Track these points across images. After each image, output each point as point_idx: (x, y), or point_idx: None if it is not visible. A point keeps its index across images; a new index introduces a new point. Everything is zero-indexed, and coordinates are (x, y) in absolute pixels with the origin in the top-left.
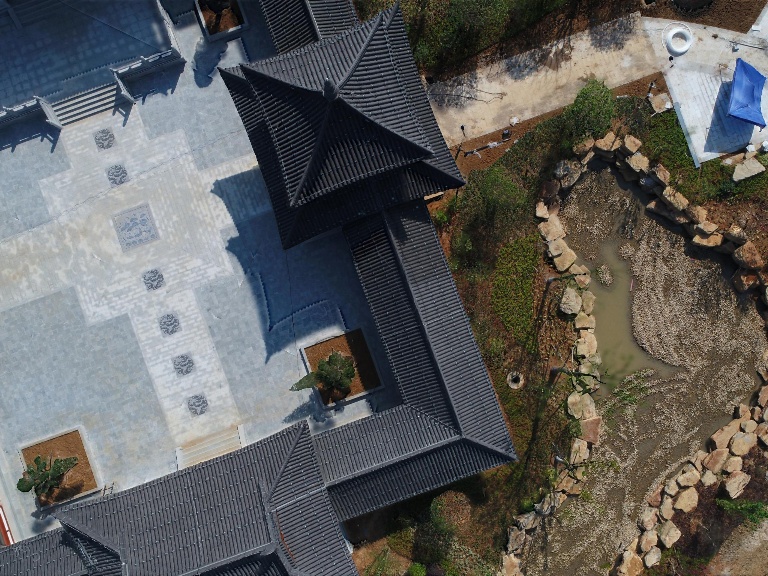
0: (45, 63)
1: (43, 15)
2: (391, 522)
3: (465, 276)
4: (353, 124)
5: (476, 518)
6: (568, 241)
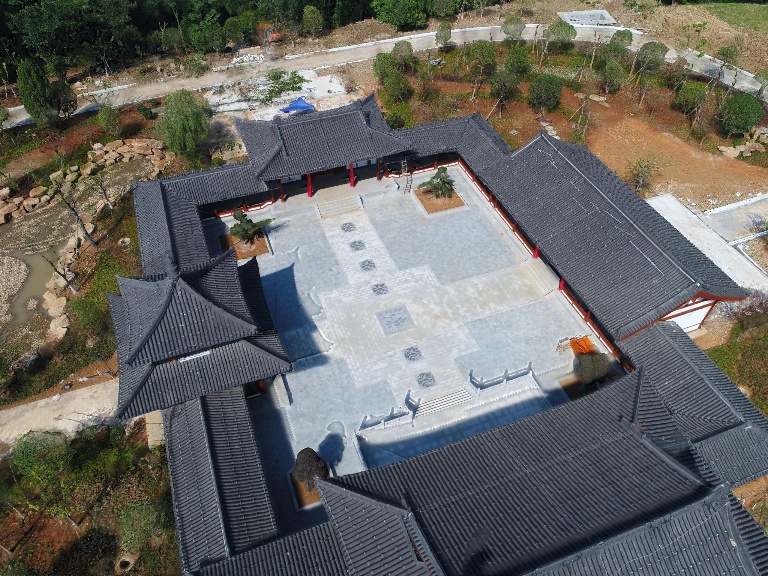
0: None
1: None
2: None
3: None
4: None
5: None
6: None
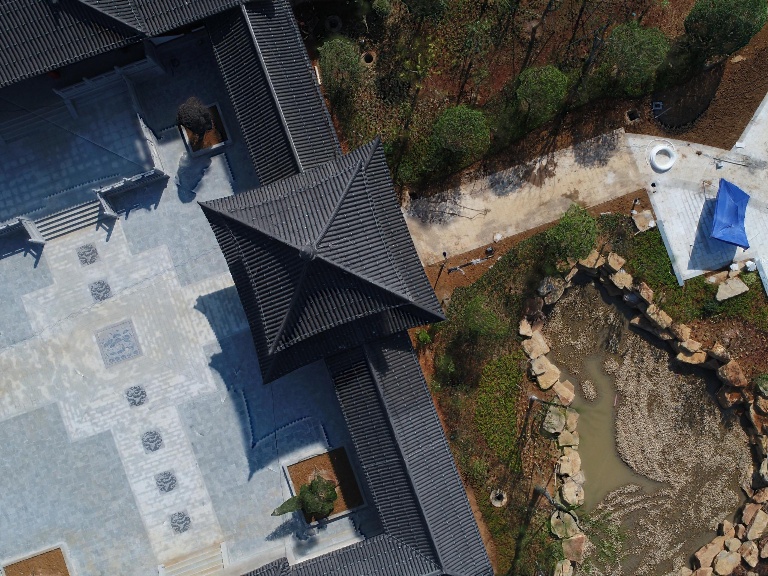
0: (28, 180)
1: (26, 132)
2: None
3: (448, 394)
4: (331, 275)
5: None
6: (552, 355)
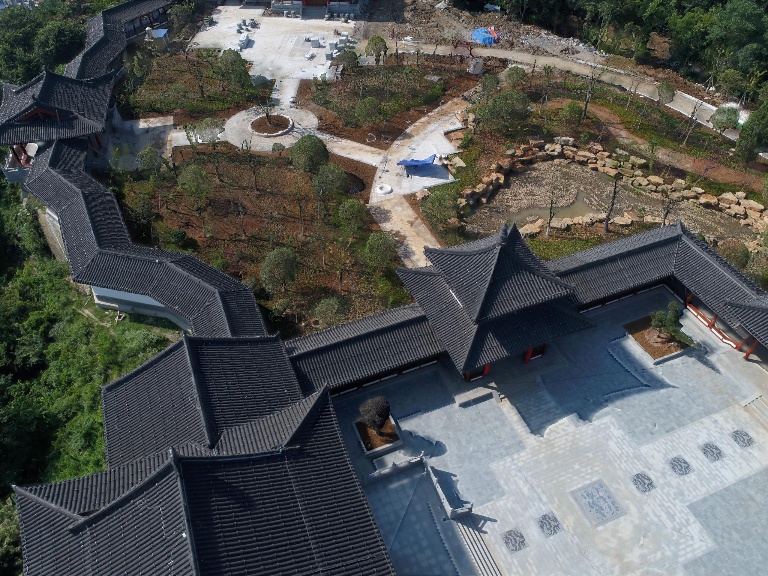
0: None
1: None
2: None
3: None
4: None
5: None
6: None
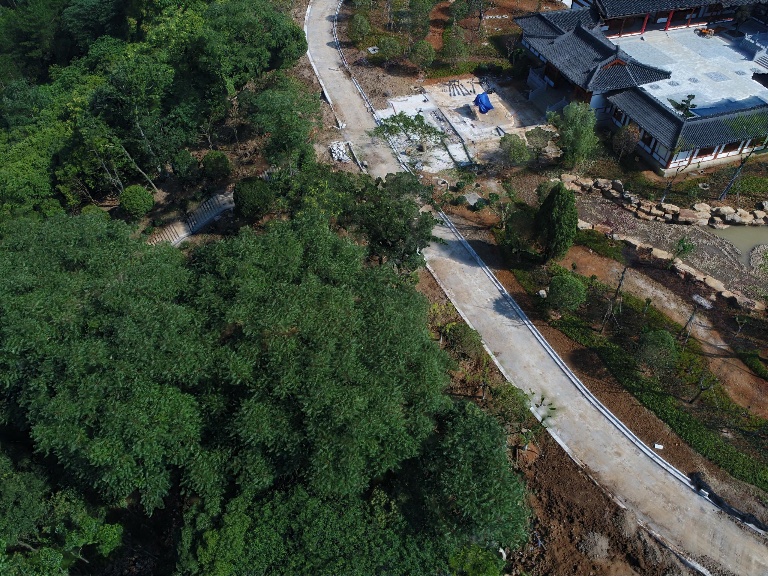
0: None
1: None
2: (599, 140)
3: None
4: None
5: (612, 169)
6: None
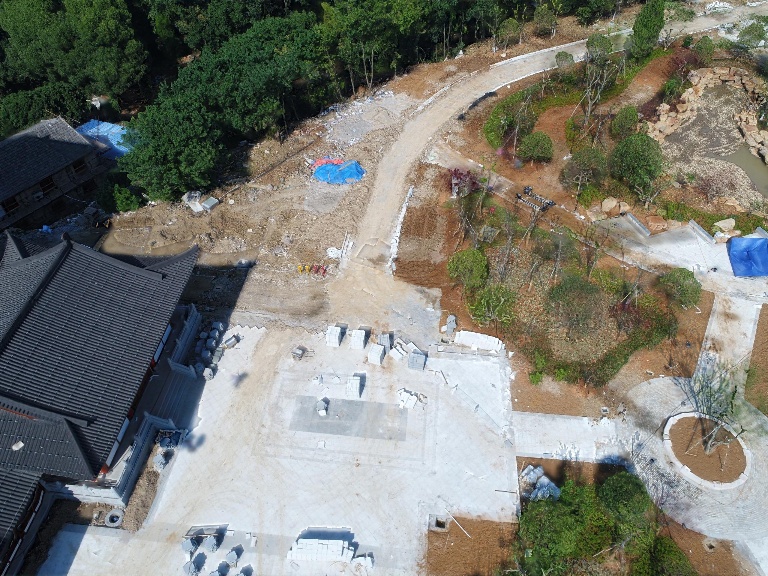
0: None
1: None
2: None
3: None
4: None
5: None
6: None
